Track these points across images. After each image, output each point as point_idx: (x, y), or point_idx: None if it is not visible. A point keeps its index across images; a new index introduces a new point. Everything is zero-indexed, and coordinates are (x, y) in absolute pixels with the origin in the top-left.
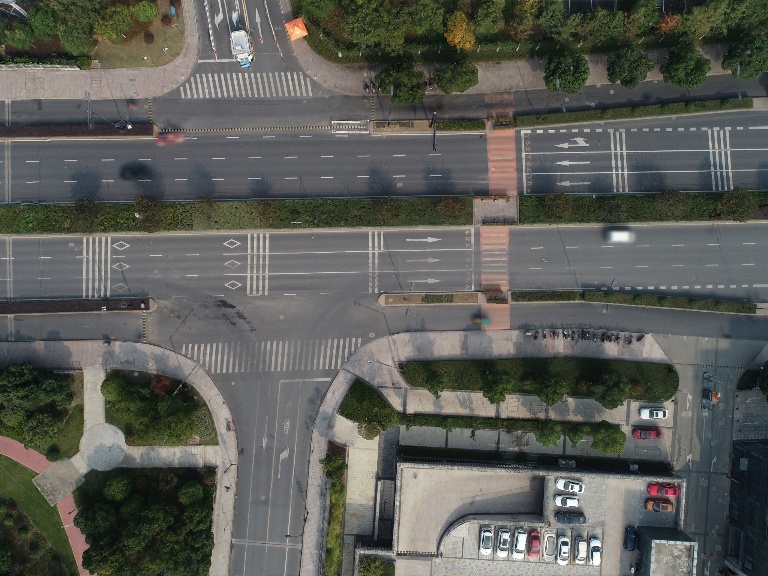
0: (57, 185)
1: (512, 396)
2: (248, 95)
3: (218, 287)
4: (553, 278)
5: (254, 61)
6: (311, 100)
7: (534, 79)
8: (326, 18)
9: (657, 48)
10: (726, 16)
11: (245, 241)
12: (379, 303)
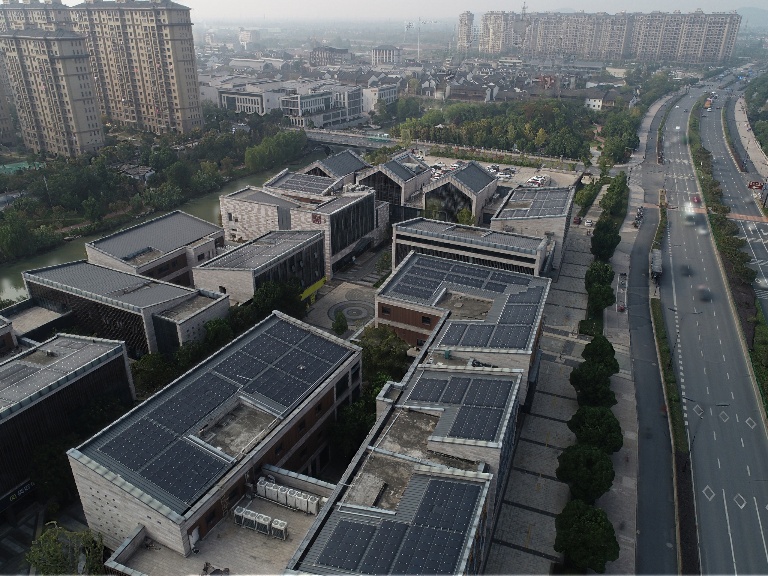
0: (714, 160)
1: None
2: None
3: None
4: None
5: None
6: None
7: None
8: None
9: None
10: None
11: None
12: None
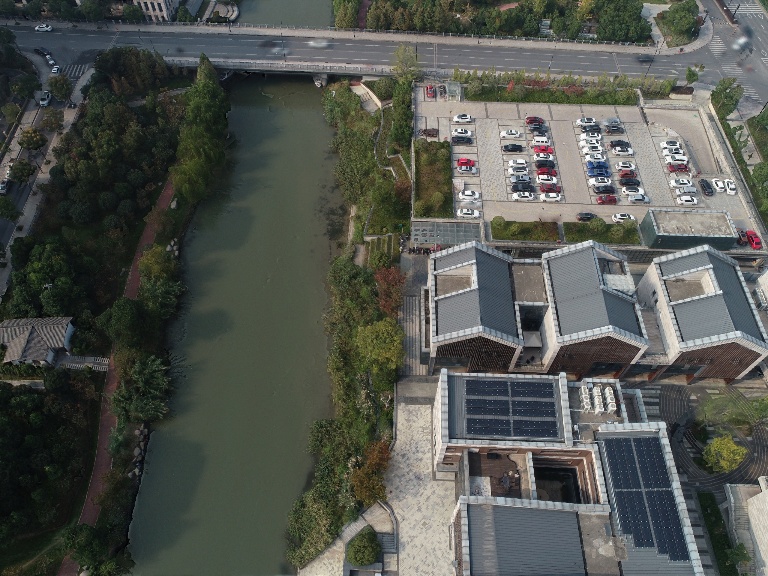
0: None
1: None
2: None
3: (759, 48)
4: None
5: None
6: None
7: None
8: None
9: None
10: None
11: None
12: None
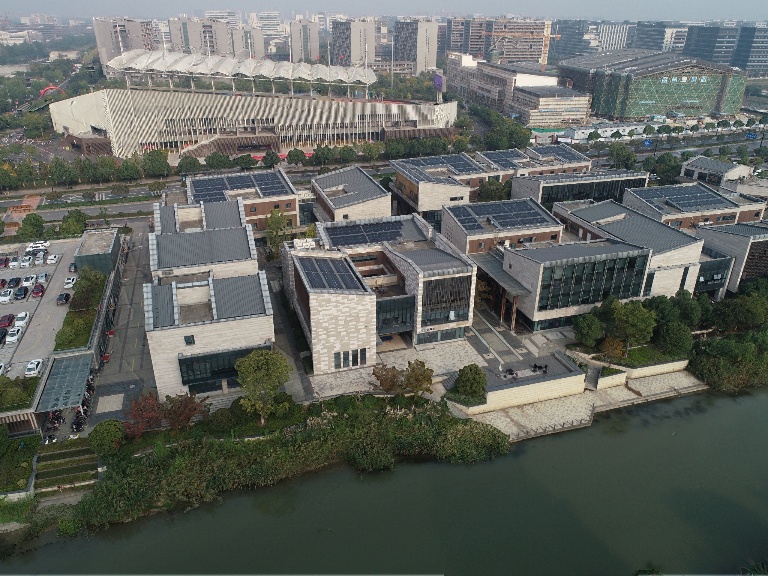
0: None
1: None
2: None
3: None
4: None
5: None
6: None
7: None
8: None
9: (123, 181)
10: (145, 162)
11: None
12: None
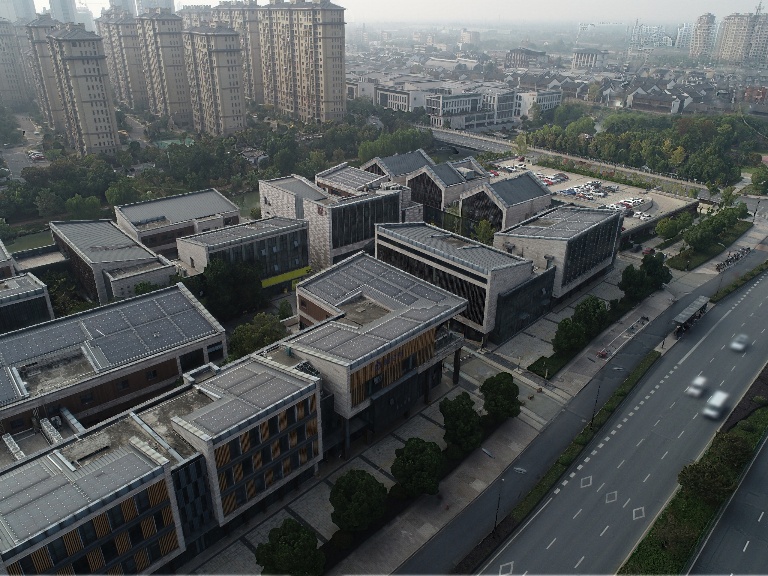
0: None
1: None
2: None
3: None
4: None
5: None
6: None
7: None
8: None
9: None
10: None
11: None
12: None
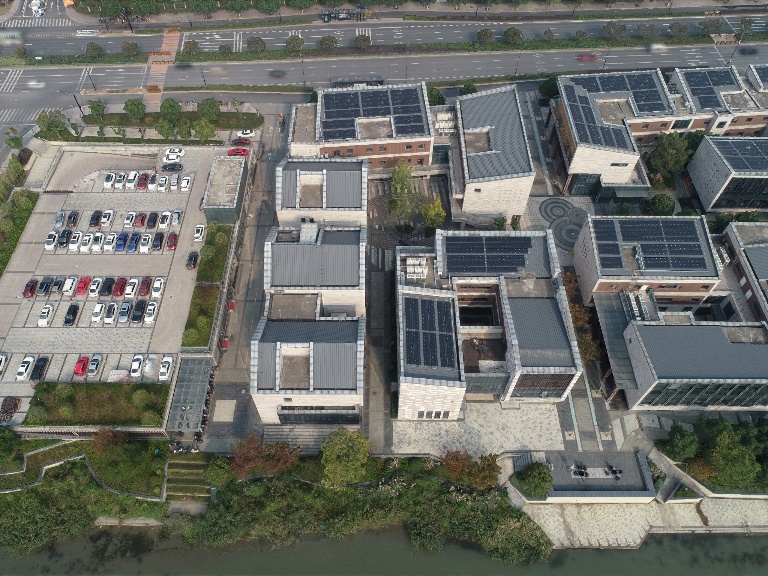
0: None
1: (154, 130)
2: (35, 26)
3: None
4: (191, 83)
5: (43, 16)
6: (69, 27)
7: (195, 18)
8: (87, 0)
9: None
10: None
11: (8, 72)
12: (80, 94)
